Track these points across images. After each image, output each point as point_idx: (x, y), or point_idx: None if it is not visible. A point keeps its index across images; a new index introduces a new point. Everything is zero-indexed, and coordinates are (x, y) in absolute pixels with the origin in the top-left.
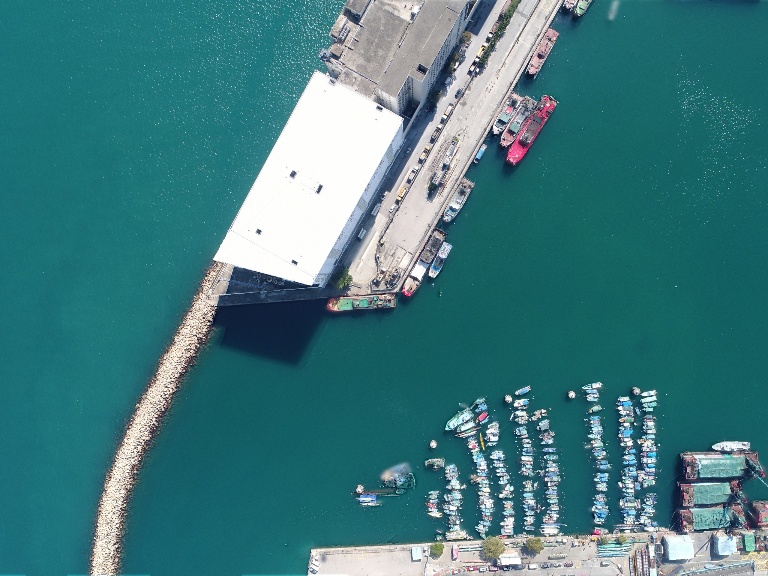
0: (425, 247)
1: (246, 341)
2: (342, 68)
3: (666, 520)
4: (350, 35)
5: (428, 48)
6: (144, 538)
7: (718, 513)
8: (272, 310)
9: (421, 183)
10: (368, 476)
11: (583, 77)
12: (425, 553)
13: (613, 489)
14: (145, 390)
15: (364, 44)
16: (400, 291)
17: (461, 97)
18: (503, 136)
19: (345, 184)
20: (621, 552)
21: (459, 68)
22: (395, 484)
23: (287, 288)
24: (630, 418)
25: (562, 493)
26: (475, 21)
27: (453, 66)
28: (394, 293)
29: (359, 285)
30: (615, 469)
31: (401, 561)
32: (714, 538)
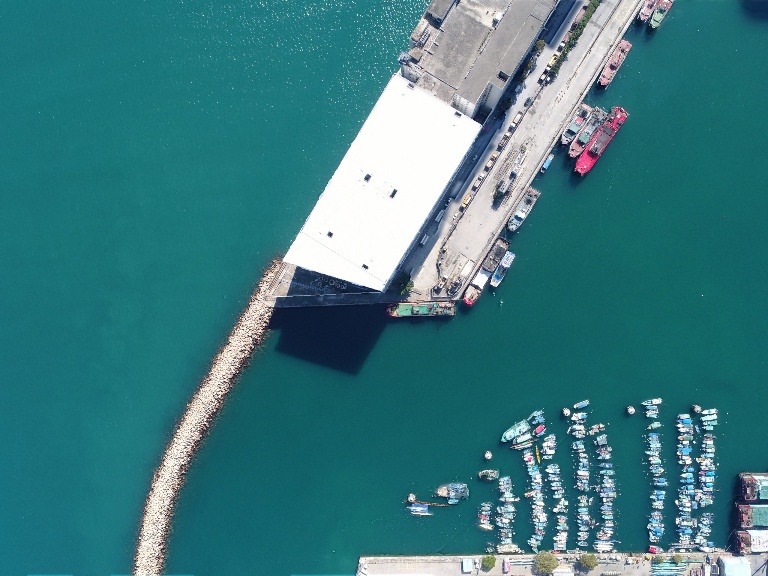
0: (488, 255)
1: (301, 344)
2: (421, 72)
3: (722, 541)
4: (430, 39)
5: (510, 55)
6: (189, 540)
7: None
8: (330, 313)
9: (486, 191)
10: (420, 485)
11: (654, 90)
12: (476, 565)
13: (669, 507)
14: (197, 390)
15: (444, 49)
16: (461, 299)
17: (530, 105)
18: (572, 146)
19: (420, 189)
20: (676, 572)
21: (529, 76)
22: (448, 494)
23: (349, 292)
24: (689, 436)
25: (617, 509)
26: (547, 29)
27: (525, 74)
28: (454, 301)
29: (419, 291)
30: (672, 487)
31: (451, 572)
32: None
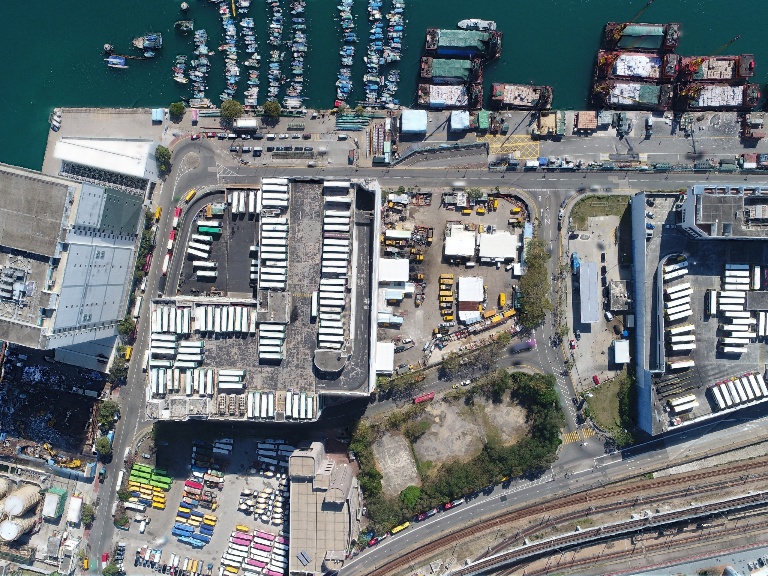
0: None
1: None
2: None
3: (408, 100)
4: None
5: None
6: None
7: (456, 89)
8: None
9: None
10: (119, 37)
11: None
12: (166, 115)
13: (359, 66)
14: None
15: None
16: None
17: None
18: None
19: None
20: (358, 125)
21: None
22: (143, 44)
23: None
24: None
25: (308, 66)
26: None
27: None
28: None
29: None
30: (362, 45)
31: (142, 124)
32: None
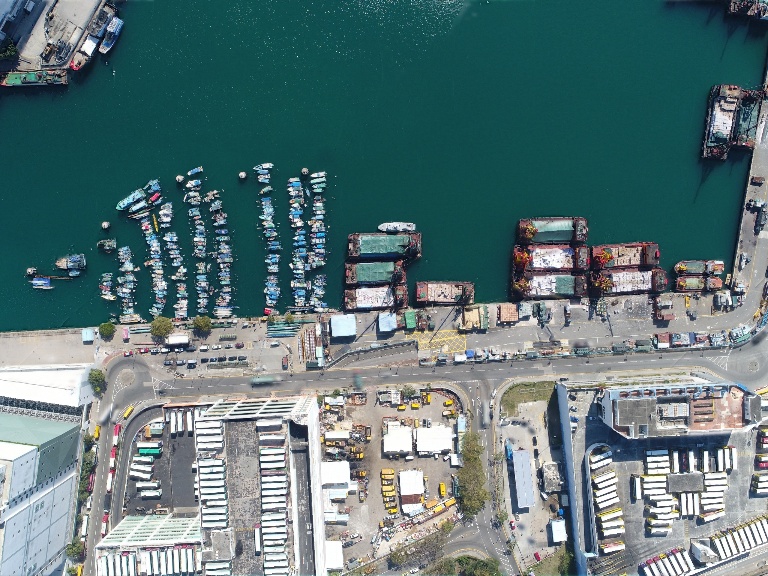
0: None
1: None
2: None
3: (336, 302)
4: None
5: None
6: None
7: (381, 291)
8: None
9: None
10: (41, 259)
11: None
12: (96, 335)
13: (285, 271)
14: None
15: None
16: None
17: None
18: None
19: None
20: (289, 332)
21: None
22: (67, 265)
23: None
24: (300, 199)
25: (235, 275)
26: None
27: None
28: (65, 69)
29: (29, 60)
30: (287, 251)
31: (73, 344)
32: (378, 317)
